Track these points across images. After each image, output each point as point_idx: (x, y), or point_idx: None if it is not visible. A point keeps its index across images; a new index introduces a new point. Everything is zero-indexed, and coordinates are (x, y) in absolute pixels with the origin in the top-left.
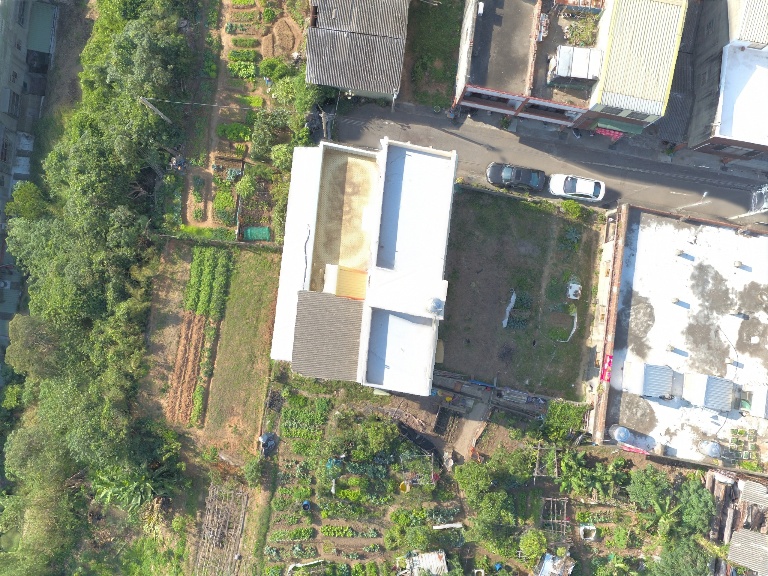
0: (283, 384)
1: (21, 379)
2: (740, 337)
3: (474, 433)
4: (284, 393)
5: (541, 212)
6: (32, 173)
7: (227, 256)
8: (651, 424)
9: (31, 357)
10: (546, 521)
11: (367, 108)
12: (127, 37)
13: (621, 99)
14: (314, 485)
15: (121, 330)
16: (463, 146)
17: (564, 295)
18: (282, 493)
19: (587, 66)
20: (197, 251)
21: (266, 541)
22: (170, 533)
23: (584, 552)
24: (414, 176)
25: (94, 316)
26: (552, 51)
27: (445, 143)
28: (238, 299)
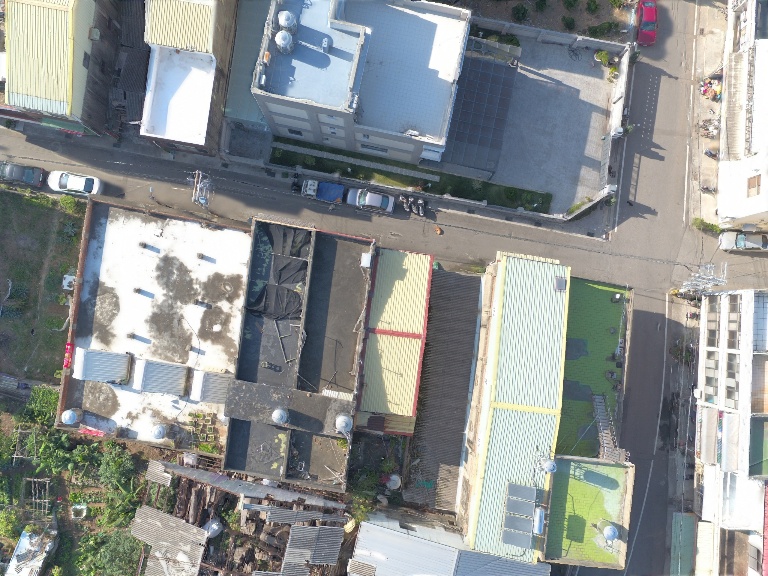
0: None
1: None
2: (202, 325)
3: None
4: None
5: (44, 207)
6: None
7: None
8: (113, 408)
9: None
10: (28, 500)
11: None
12: None
13: (27, 99)
14: None
15: None
16: None
17: None
18: None
19: None
20: None
21: None
22: None
23: (76, 530)
24: None
25: None
26: None
27: None
28: None
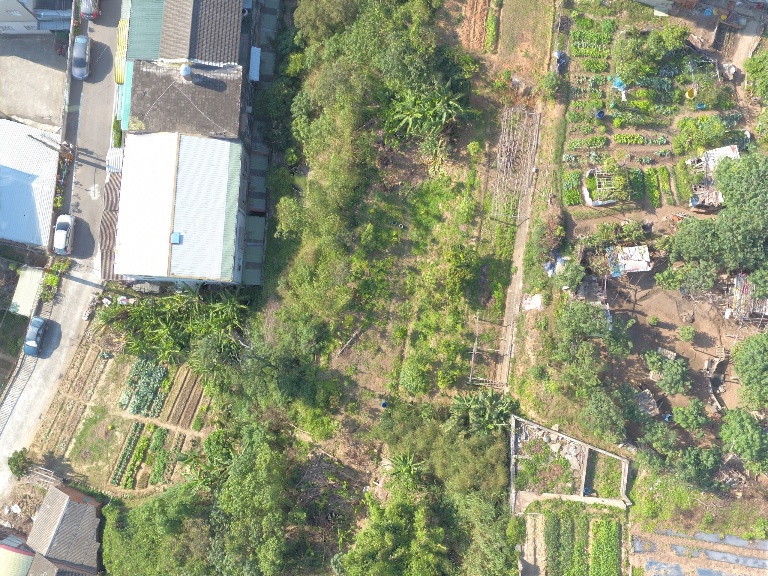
0: (569, 9)
1: None
2: None
3: (749, 47)
4: (574, 13)
5: None
6: None
7: None
8: None
9: None
10: None
11: None
12: None
13: None
14: (604, 99)
15: None
16: None
17: None
18: (576, 106)
19: None
20: None
21: (564, 150)
22: (458, 169)
23: None
24: None
25: None
26: None
27: None
28: None
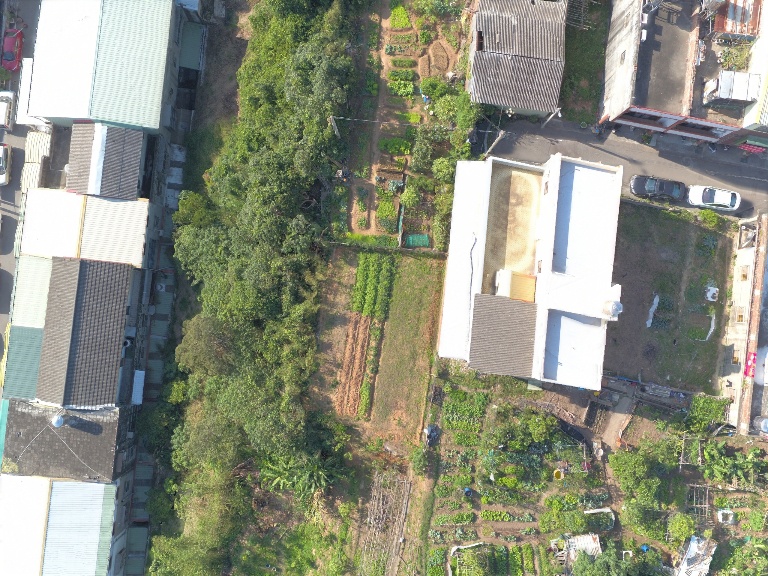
0: (444, 380)
1: (183, 376)
2: None
3: (620, 425)
4: (446, 388)
5: (680, 220)
6: (186, 183)
7: (391, 261)
8: None
9: (210, 355)
10: (690, 506)
11: (519, 124)
12: (305, 59)
13: None
14: (473, 473)
15: (296, 330)
16: (607, 159)
17: (702, 297)
18: (444, 481)
19: (747, 89)
20: (363, 257)
21: (430, 525)
22: (331, 519)
23: (722, 534)
24: (583, 189)
25: (270, 317)
26: (706, 74)
27: (591, 157)
28: (400, 301)
